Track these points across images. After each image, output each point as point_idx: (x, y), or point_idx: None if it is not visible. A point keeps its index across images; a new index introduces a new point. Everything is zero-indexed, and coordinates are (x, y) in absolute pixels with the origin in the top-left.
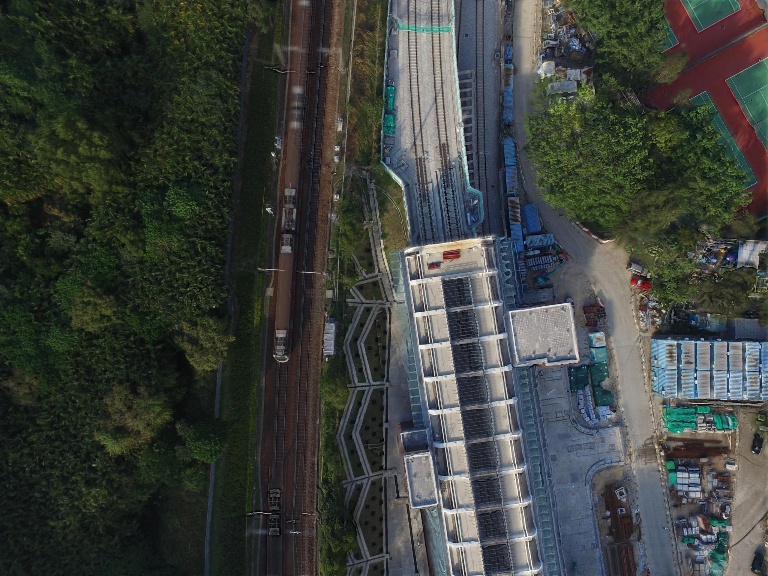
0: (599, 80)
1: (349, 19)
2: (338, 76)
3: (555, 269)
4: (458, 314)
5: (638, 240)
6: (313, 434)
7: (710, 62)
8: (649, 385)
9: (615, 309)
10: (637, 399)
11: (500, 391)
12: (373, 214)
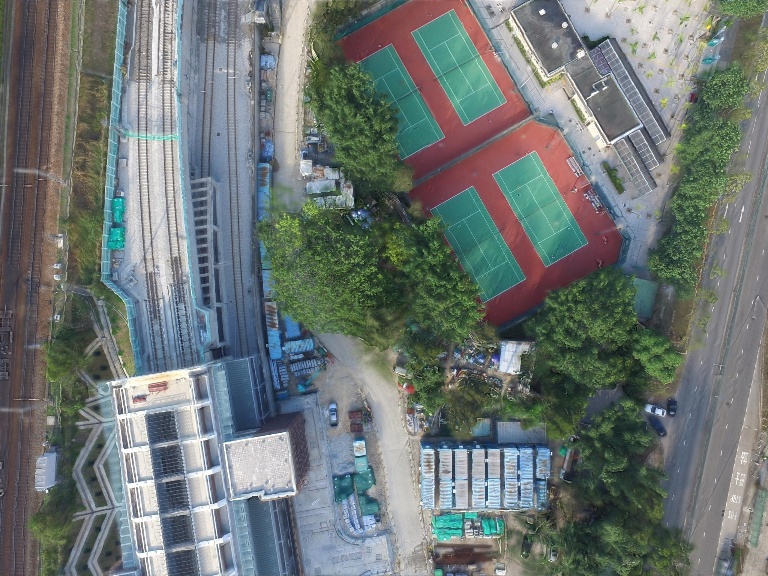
0: (355, 180)
1: (71, 128)
2: (59, 189)
3: (312, 377)
4: (164, 450)
5: (399, 344)
6: (32, 572)
7: (476, 156)
8: (419, 490)
9: (383, 412)
10: (407, 505)
11: (209, 530)
12: (105, 331)
